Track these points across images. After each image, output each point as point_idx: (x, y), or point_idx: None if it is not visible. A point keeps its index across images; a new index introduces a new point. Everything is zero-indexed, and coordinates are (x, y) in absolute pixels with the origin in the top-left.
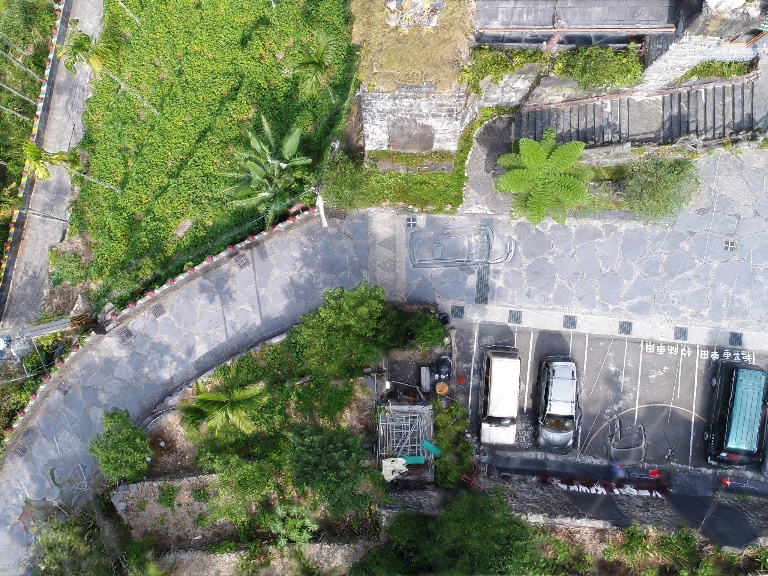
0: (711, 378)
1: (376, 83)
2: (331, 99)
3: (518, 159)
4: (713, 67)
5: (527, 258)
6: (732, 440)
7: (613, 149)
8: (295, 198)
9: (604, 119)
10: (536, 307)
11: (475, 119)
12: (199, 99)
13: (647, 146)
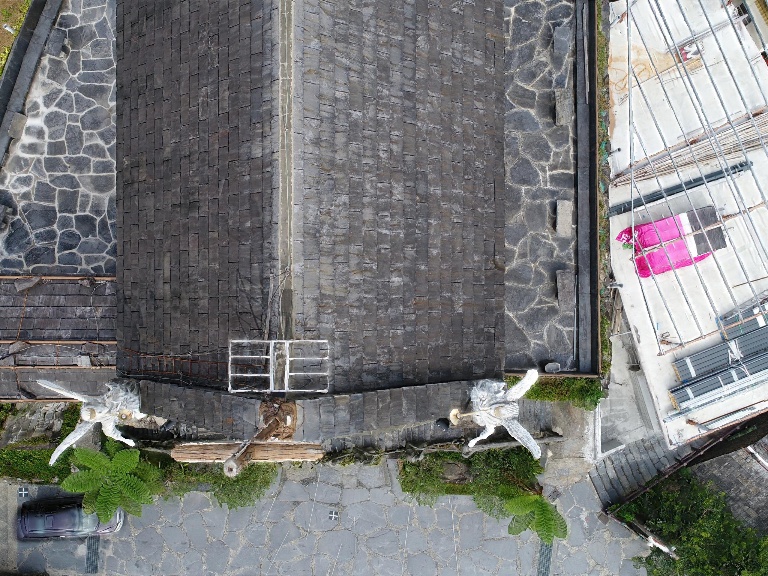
0: None
1: None
2: None
3: None
4: None
5: (136, 528)
6: None
7: None
8: None
9: None
10: None
11: None
12: None
13: None
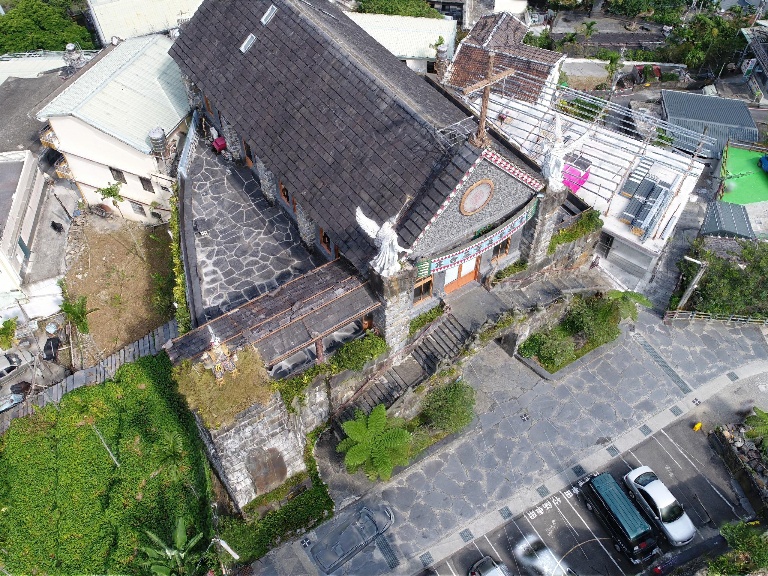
0: (586, 507)
1: (220, 422)
2: (195, 499)
3: (349, 441)
4: (423, 318)
5: (405, 512)
6: (630, 531)
7: (403, 397)
8: (204, 575)
9: (387, 388)
10: (436, 542)
11: (307, 444)
12: (84, 573)
13: (423, 384)
